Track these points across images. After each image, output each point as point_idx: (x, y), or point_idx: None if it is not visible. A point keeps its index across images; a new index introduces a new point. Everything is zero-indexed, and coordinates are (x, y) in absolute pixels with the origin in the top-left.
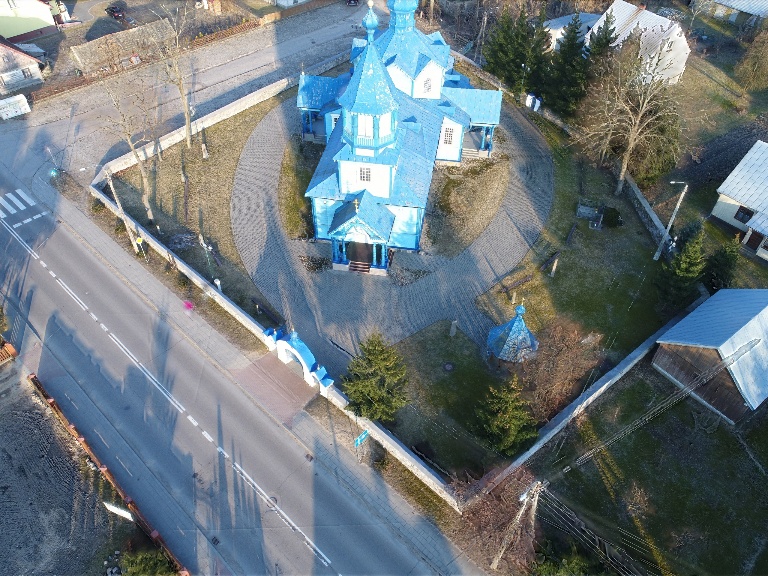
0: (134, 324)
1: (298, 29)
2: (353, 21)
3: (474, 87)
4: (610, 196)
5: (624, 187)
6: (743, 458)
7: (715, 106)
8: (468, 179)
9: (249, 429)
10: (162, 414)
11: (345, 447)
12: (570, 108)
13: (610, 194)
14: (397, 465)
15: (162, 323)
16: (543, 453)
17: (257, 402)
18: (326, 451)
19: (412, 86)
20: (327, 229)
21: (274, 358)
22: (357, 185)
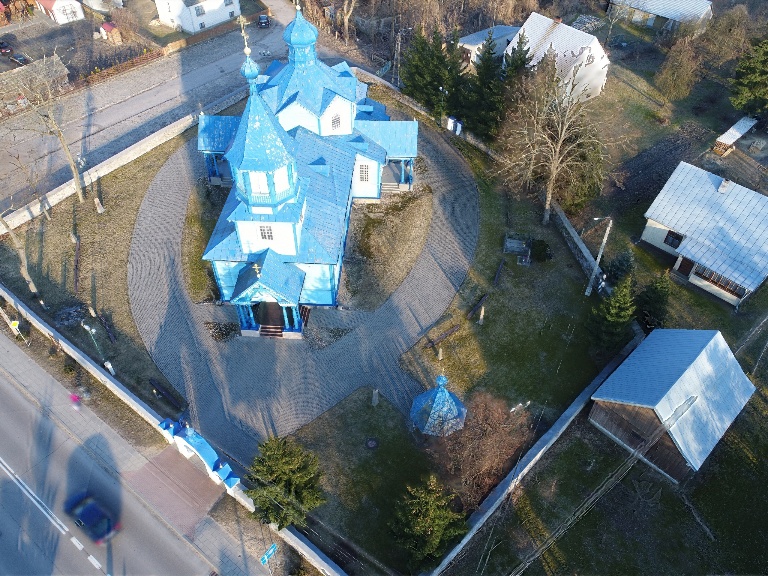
0: (10, 425)
1: (205, 57)
2: (265, 45)
3: (393, 112)
4: (538, 226)
5: (551, 215)
6: (690, 522)
7: (638, 118)
8: (389, 217)
9: (144, 547)
10: (40, 539)
11: (255, 558)
12: (491, 132)
13: (538, 223)
14: (315, 575)
15: (44, 421)
16: (477, 540)
17: (154, 511)
18: (233, 566)
19: (319, 124)
20: (233, 291)
21: (174, 452)
22: (259, 244)
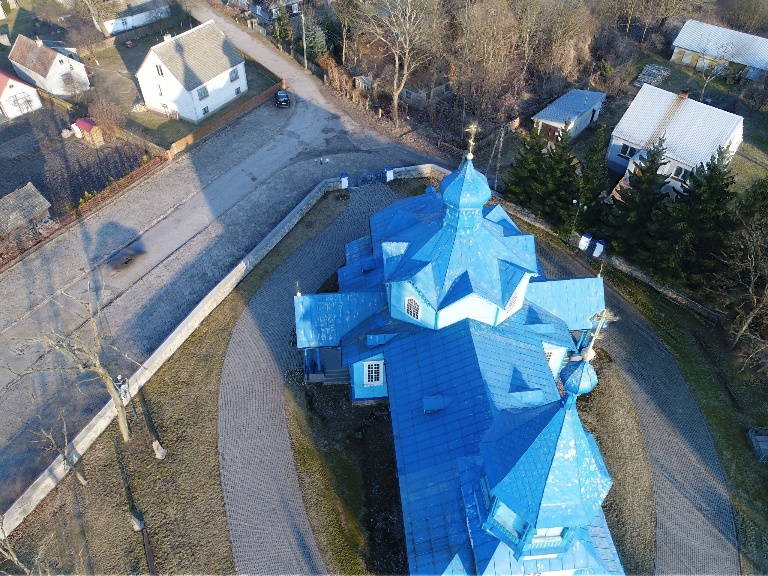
0: None
1: (224, 158)
2: (294, 133)
3: None
4: None
5: None
6: None
7: None
8: None
9: None
10: None
11: None
12: (664, 264)
13: None
14: None
15: None
16: None
17: None
18: None
19: (497, 314)
20: None
21: None
22: None
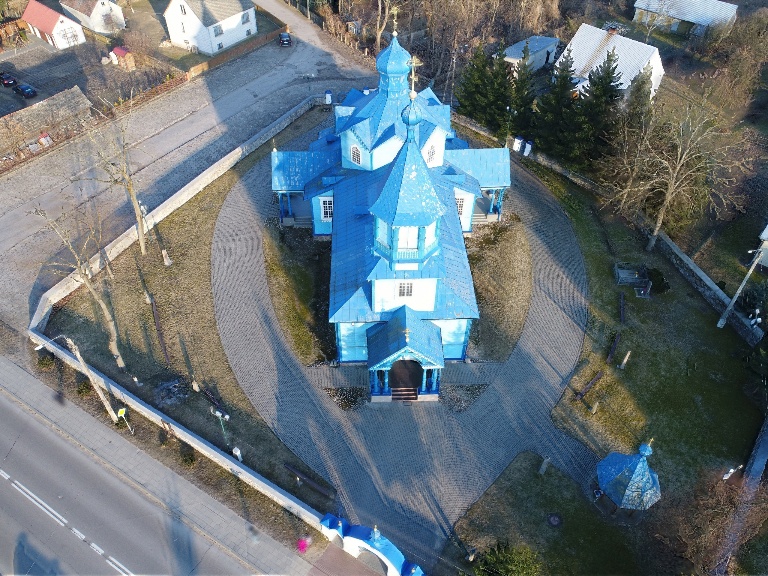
0: (138, 535)
1: (233, 81)
2: (292, 65)
3: None
4: (642, 252)
5: None
6: None
7: None
8: (485, 252)
9: None
10: None
11: None
12: (572, 154)
13: (641, 250)
14: None
15: (176, 526)
16: None
17: None
18: None
19: None
20: (354, 351)
21: (339, 551)
22: (394, 302)
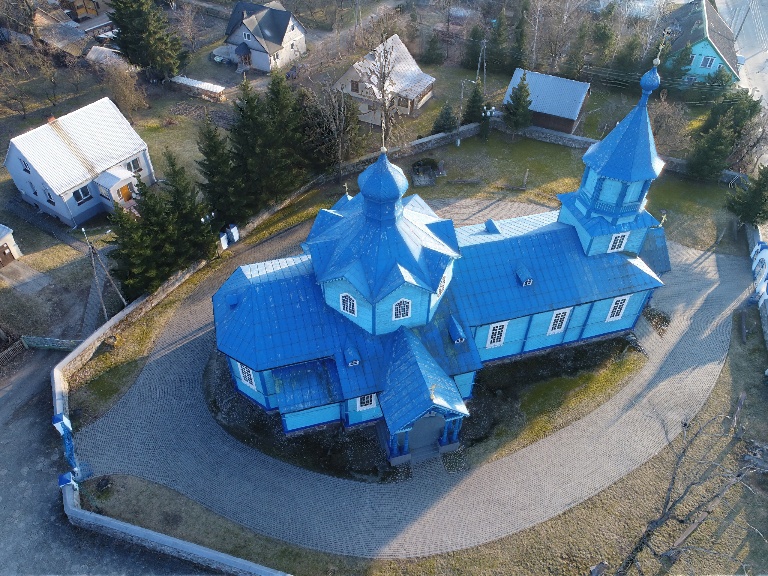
0: None
1: None
2: None
3: None
4: None
5: None
6: None
7: (162, 135)
8: None
9: None
10: None
11: None
12: (280, 185)
13: None
14: None
15: None
16: None
17: None
18: None
19: None
20: None
21: None
22: None
